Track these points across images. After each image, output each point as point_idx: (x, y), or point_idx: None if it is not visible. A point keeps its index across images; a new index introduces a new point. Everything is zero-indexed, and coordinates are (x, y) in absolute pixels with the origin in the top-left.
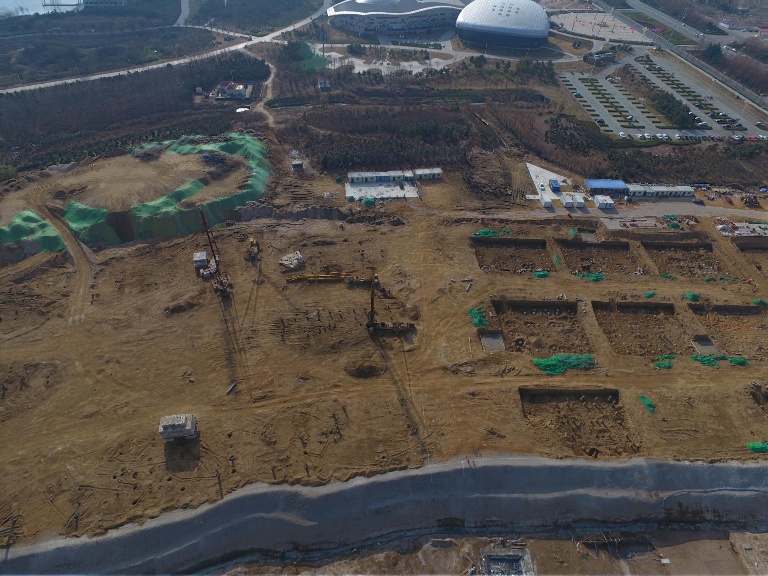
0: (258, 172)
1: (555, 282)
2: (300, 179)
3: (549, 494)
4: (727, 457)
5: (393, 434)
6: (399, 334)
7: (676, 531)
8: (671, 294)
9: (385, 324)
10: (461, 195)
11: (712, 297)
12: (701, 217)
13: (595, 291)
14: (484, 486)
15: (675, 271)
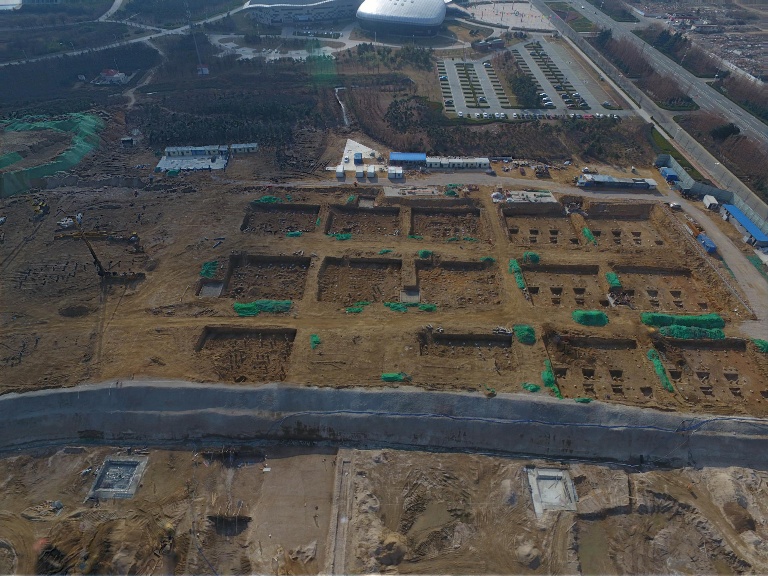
0: (79, 146)
1: (302, 241)
2: (123, 153)
3: (181, 412)
4: (356, 384)
5: (67, 361)
6: (127, 282)
7: (293, 447)
8: (405, 251)
9: (117, 273)
10: (264, 167)
11: (444, 254)
12: (484, 186)
13: (335, 248)
14: (125, 404)
15: (430, 233)
